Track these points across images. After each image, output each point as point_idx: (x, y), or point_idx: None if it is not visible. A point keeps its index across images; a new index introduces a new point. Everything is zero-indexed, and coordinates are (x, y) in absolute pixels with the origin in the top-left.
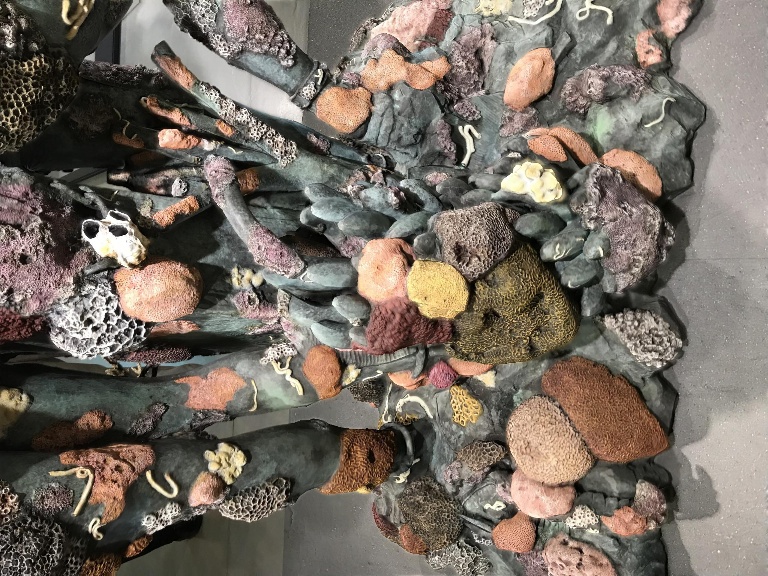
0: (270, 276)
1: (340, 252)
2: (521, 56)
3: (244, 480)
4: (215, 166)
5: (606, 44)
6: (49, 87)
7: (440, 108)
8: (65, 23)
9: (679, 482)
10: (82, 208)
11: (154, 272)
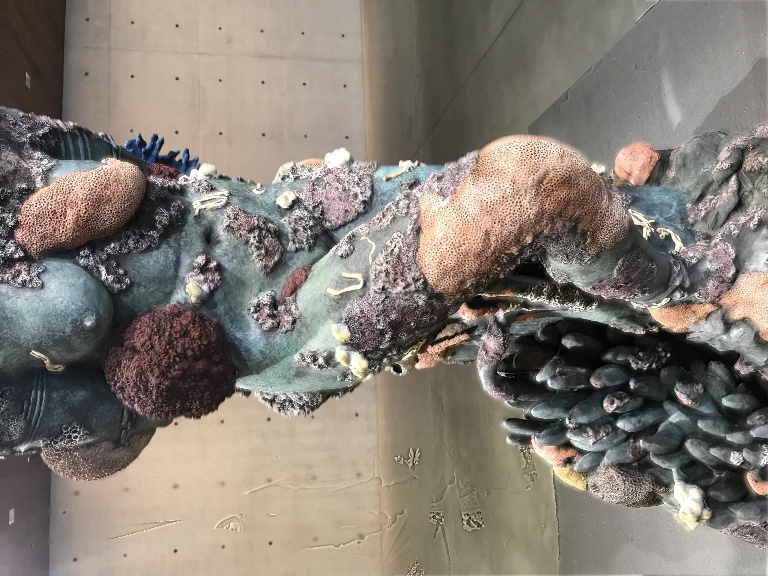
0: None
1: None
2: None
3: None
4: (490, 345)
5: None
6: None
7: (767, 359)
8: None
9: None
10: None
11: None
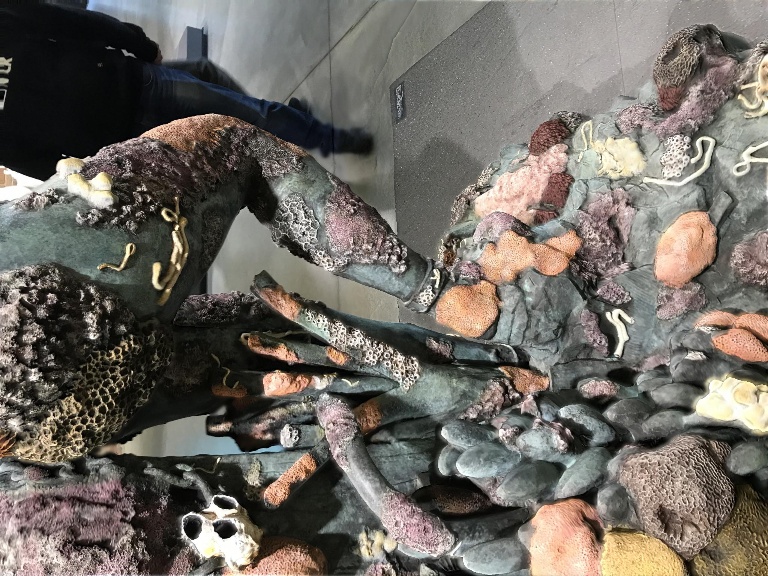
0: (410, 550)
1: (489, 498)
2: (668, 222)
3: None
4: (332, 415)
5: None
6: (140, 368)
7: (580, 294)
8: (156, 289)
9: None
10: (181, 492)
11: (270, 569)
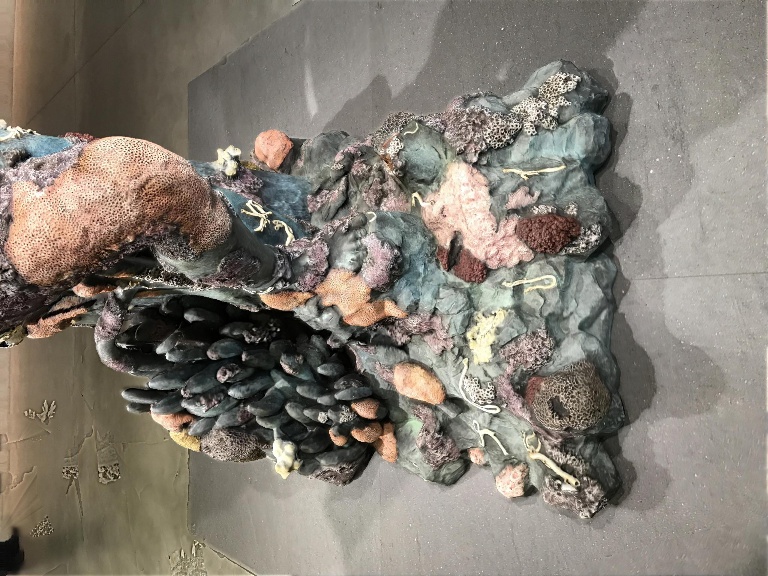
0: None
1: None
2: (438, 373)
3: None
4: (107, 321)
5: None
6: None
7: None
8: None
9: None
10: None
11: (28, 331)
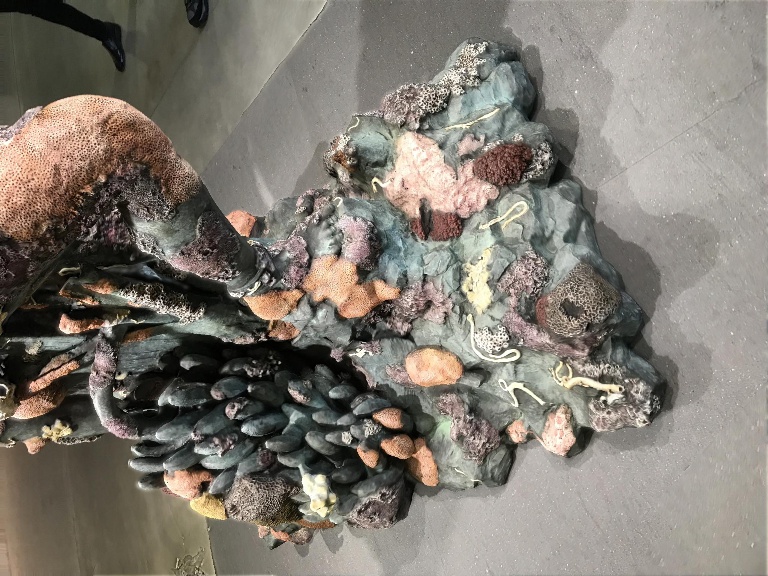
0: None
1: None
2: (448, 346)
3: (68, 436)
4: (100, 364)
5: (503, 401)
6: None
7: (351, 337)
8: None
9: (333, 528)
10: None
11: (21, 409)
